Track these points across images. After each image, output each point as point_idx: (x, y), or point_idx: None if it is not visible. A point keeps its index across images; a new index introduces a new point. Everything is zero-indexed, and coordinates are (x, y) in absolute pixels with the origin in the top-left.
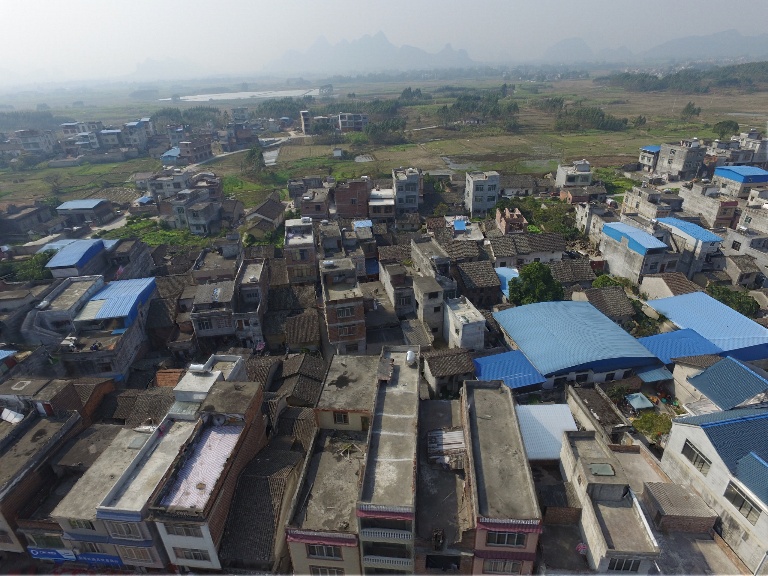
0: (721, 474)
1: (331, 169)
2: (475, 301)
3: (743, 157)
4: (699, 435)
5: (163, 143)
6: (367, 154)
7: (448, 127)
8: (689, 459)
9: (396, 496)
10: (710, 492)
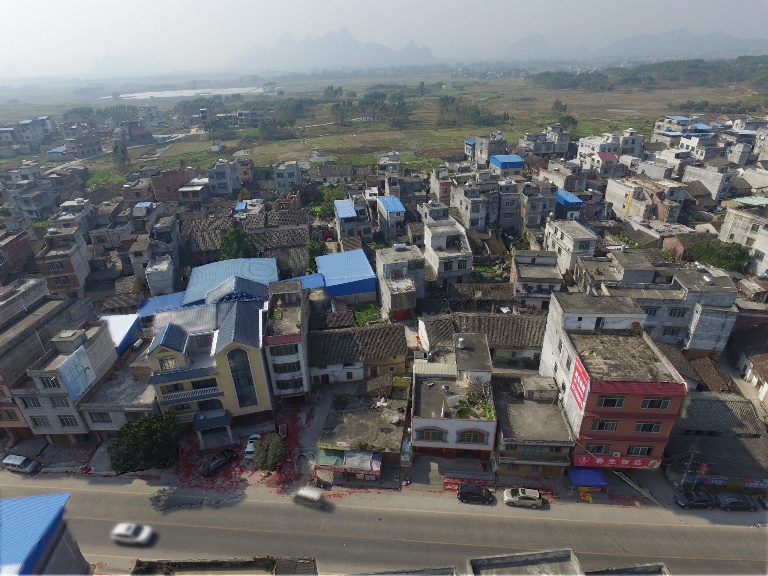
0: None
1: (182, 162)
2: (204, 262)
3: (545, 148)
4: None
5: (58, 140)
6: (249, 149)
7: (343, 123)
8: None
9: None
10: None
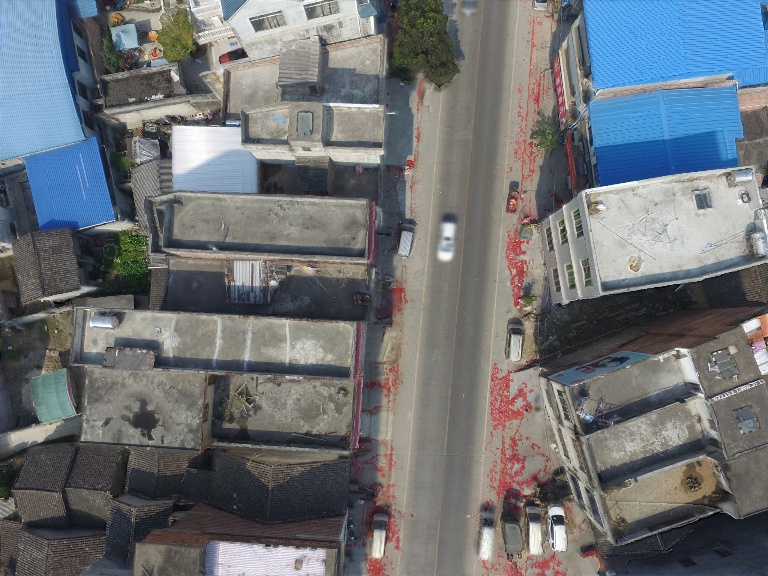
0: (295, 10)
1: None
2: None
3: None
4: (255, 4)
5: None
6: None
7: None
8: (264, 29)
9: (336, 340)
10: (299, 30)
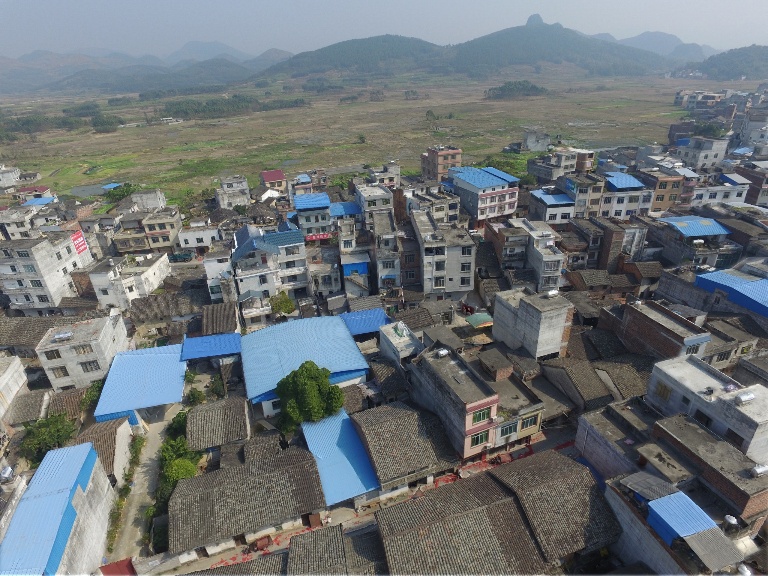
0: None
1: None
2: None
3: None
4: None
5: None
6: None
7: None
8: None
9: None
10: None
